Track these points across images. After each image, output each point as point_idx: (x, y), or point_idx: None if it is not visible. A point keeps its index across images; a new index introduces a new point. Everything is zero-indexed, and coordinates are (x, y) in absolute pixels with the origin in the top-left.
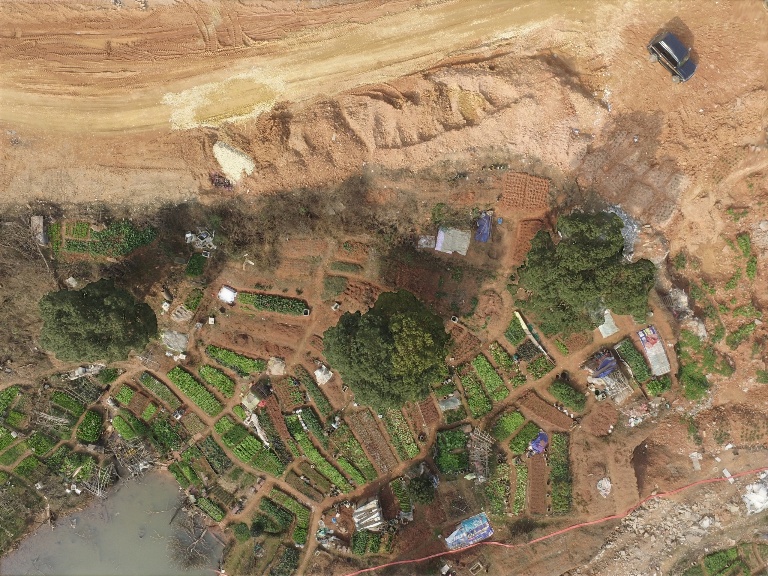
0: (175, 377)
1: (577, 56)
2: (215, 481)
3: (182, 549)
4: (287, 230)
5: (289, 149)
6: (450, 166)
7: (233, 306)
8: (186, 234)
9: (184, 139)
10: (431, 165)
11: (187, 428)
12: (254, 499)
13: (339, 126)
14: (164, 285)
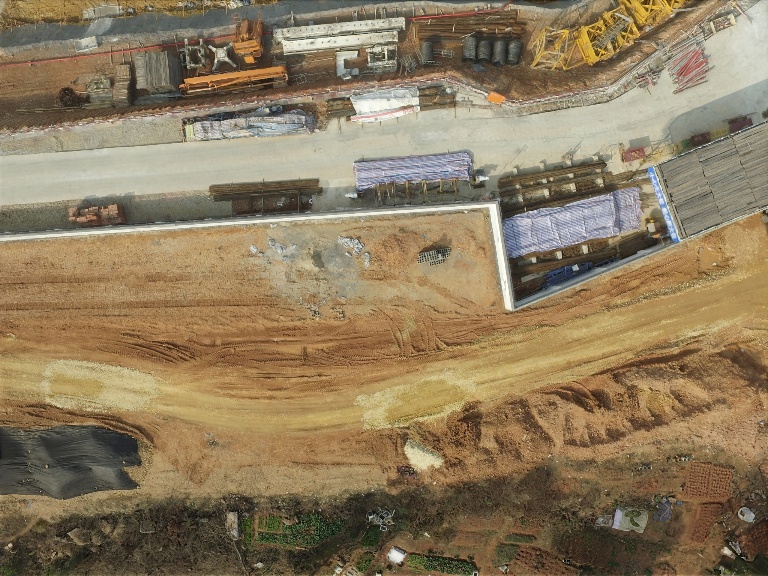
0: None
1: (764, 351)
2: None
3: None
4: None
5: (479, 448)
6: (635, 458)
7: (402, 566)
8: (369, 516)
9: (375, 437)
10: (616, 457)
11: None
12: None
13: (530, 427)
14: (340, 555)
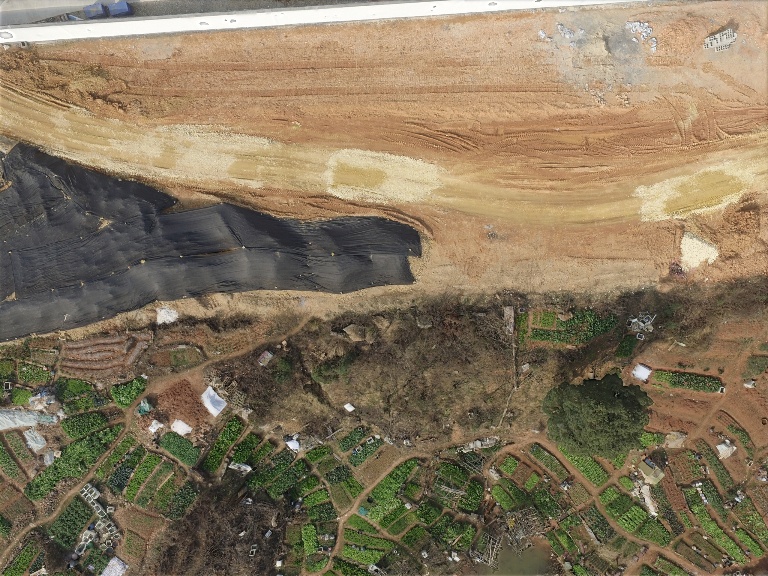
0: None
1: None
2: (592, 549)
3: None
4: None
5: (757, 239)
6: None
7: (647, 384)
8: (633, 319)
9: (652, 230)
10: None
11: (572, 498)
12: (633, 567)
13: None
14: (593, 366)
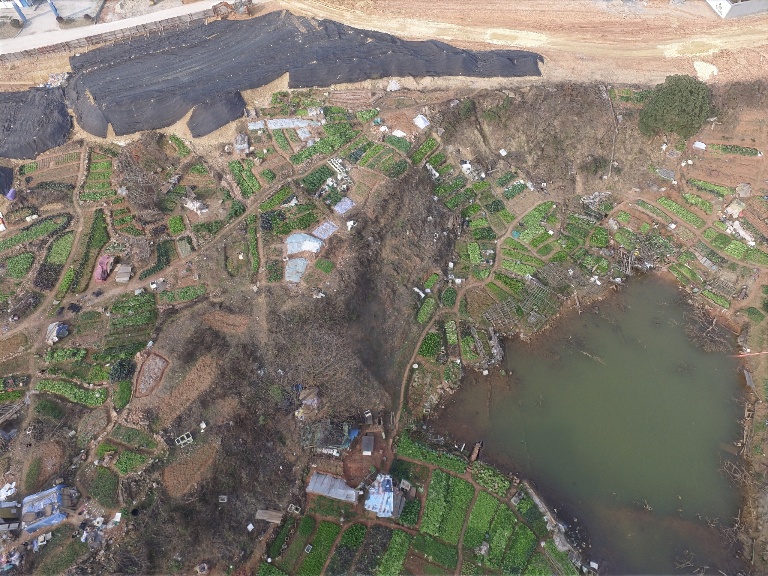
0: (664, 202)
1: None
2: (713, 277)
3: (700, 333)
4: None
5: (738, 63)
6: None
7: (706, 151)
8: None
9: (674, 61)
10: None
11: (681, 236)
12: (754, 289)
13: (762, 55)
14: (665, 133)
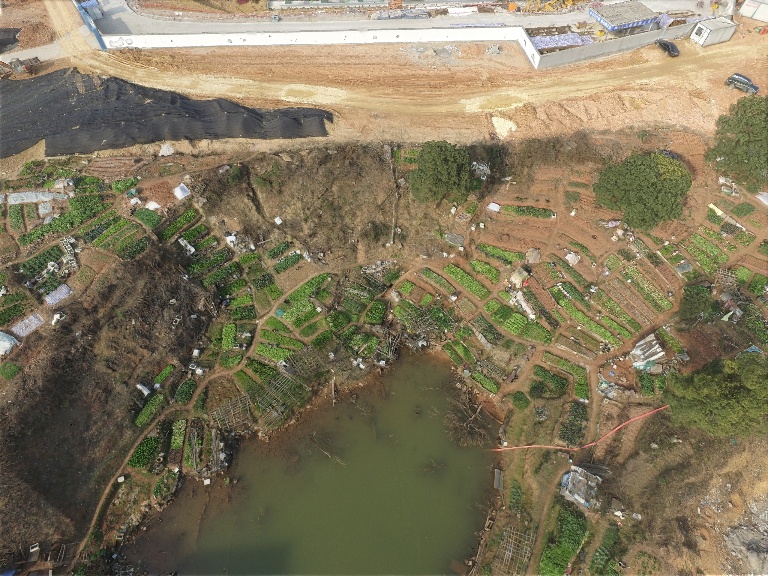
0: (450, 270)
1: None
2: (487, 356)
3: (460, 424)
4: (537, 163)
5: (537, 118)
6: (635, 128)
7: (499, 214)
8: (474, 162)
9: (473, 116)
10: (623, 128)
11: (461, 309)
12: (526, 369)
13: None
14: None
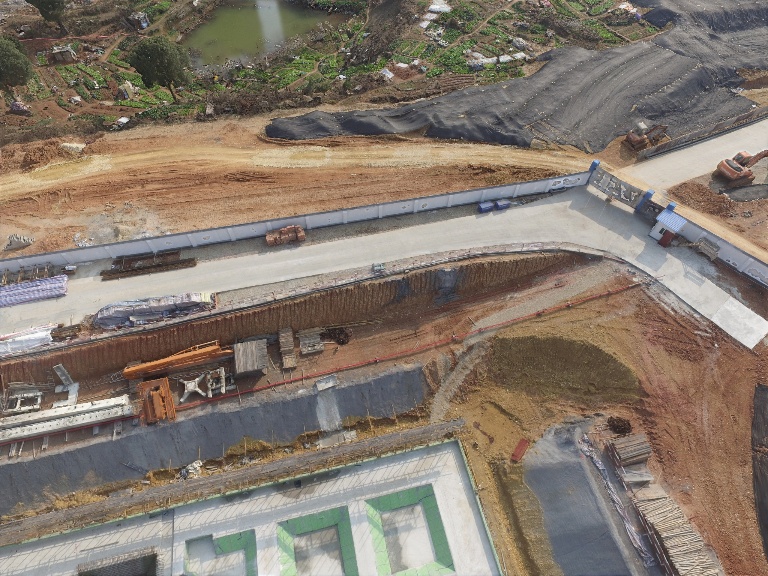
0: None
1: None
2: None
3: None
4: None
5: None
6: None
7: None
8: None
9: None
10: None
11: None
12: None
13: None
14: None
